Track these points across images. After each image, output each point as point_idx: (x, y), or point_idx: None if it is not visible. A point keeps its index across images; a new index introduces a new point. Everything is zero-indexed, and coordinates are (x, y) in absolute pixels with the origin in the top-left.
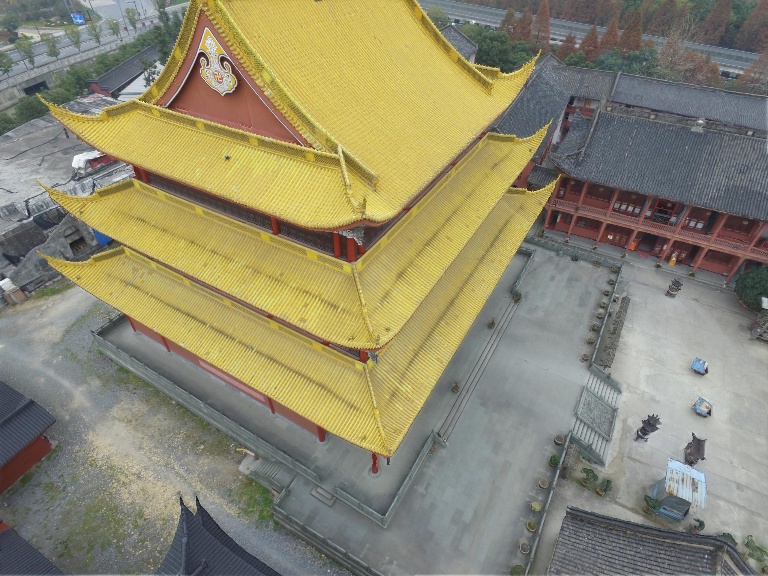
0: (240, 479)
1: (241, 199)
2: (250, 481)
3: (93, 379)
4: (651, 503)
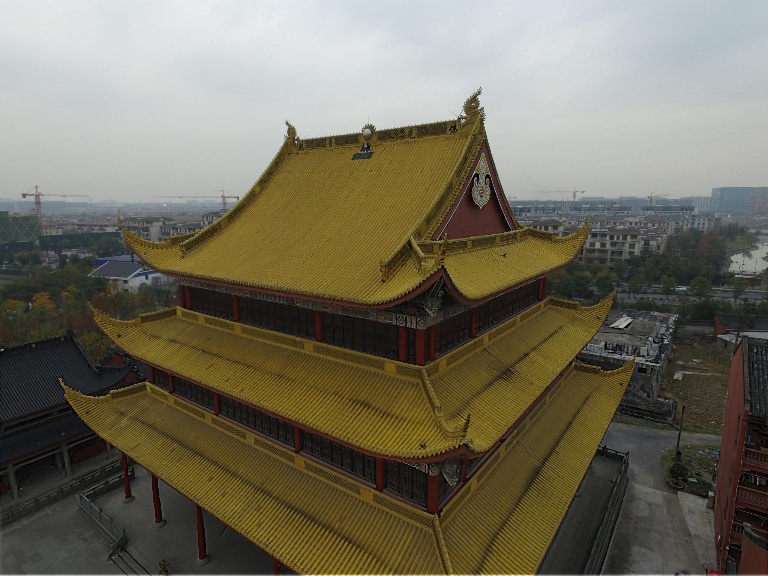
0: None
1: None
2: None
3: None
4: None
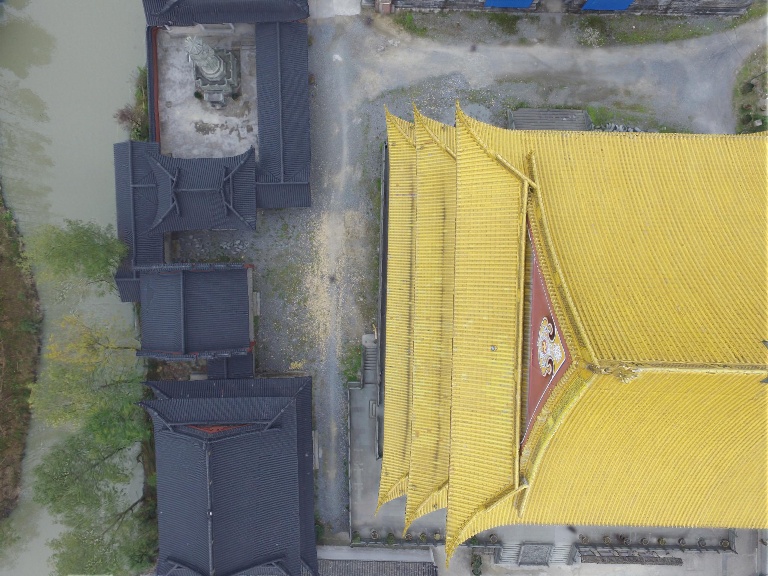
0: (357, 342)
1: (455, 391)
2: (360, 350)
3: (360, 169)
4: None
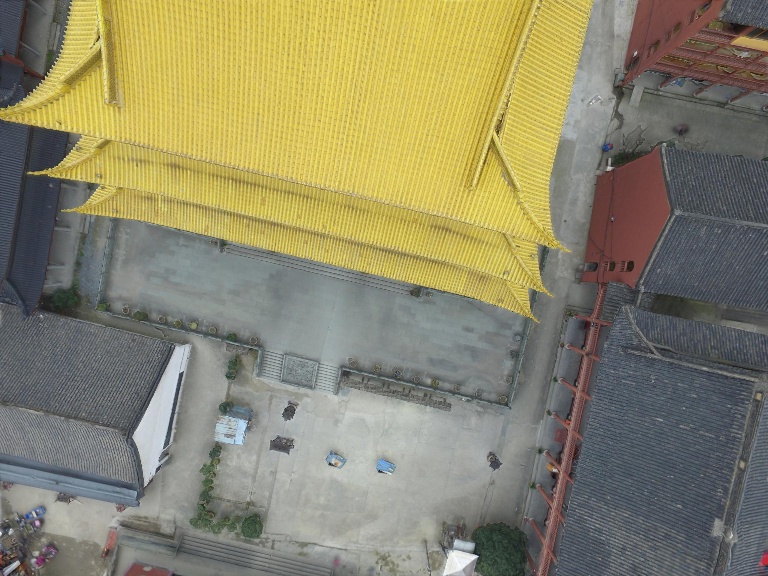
0: None
1: None
2: None
3: None
4: (220, 406)
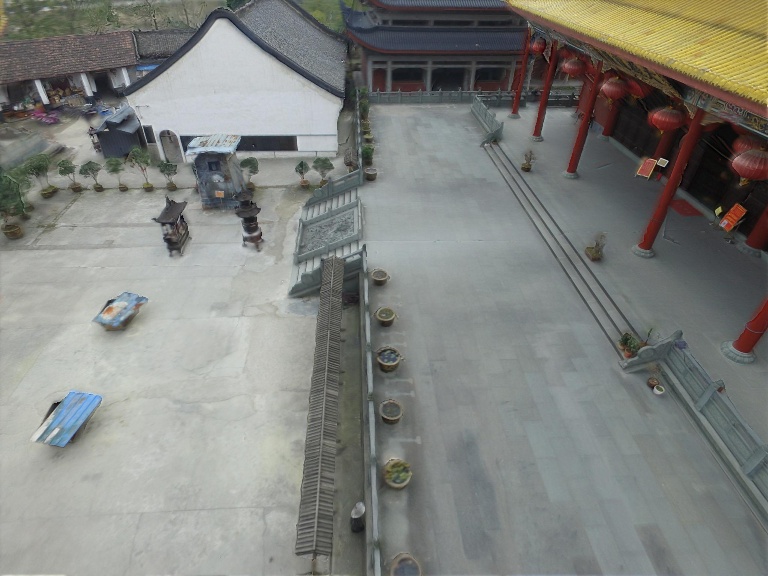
0: None
1: None
2: None
3: None
4: None
